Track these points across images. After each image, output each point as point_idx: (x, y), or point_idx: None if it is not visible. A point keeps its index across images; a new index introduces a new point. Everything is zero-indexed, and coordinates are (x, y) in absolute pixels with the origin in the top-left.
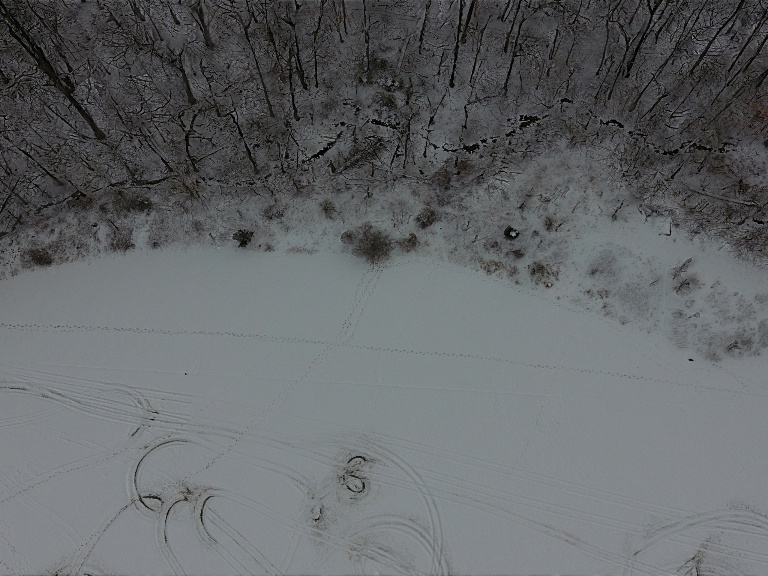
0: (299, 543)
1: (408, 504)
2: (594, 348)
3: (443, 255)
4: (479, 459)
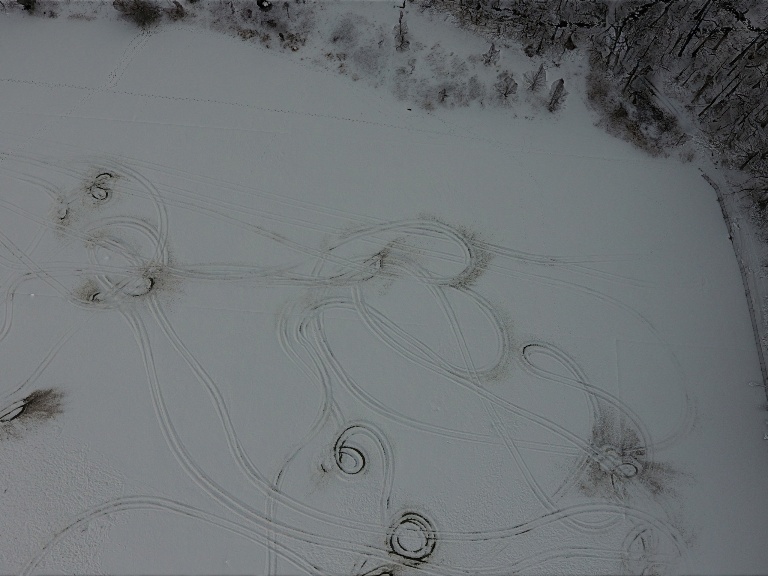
0: (44, 234)
1: (142, 209)
2: (326, 98)
3: (206, 24)
4: (210, 178)
